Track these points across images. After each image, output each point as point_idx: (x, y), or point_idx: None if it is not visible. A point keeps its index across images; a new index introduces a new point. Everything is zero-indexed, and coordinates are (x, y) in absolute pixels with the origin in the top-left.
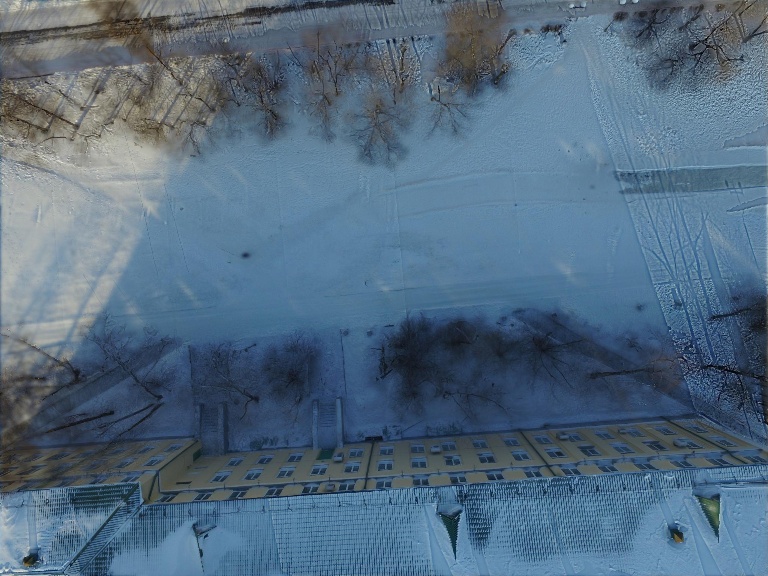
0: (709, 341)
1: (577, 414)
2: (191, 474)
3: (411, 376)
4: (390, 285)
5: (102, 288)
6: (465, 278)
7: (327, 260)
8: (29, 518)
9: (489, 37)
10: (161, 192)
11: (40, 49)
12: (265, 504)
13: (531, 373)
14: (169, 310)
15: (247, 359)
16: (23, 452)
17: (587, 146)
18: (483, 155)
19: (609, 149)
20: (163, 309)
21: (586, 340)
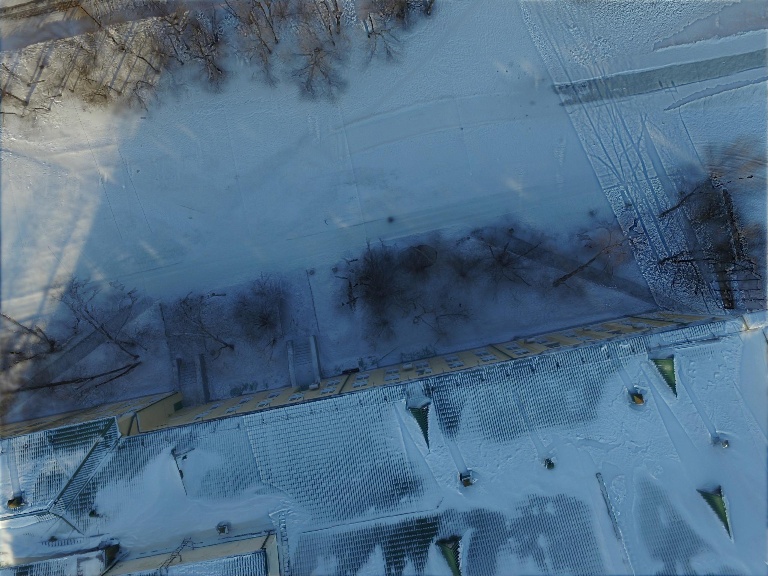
0: (662, 237)
1: (545, 323)
2: (172, 420)
3: (379, 304)
4: (350, 221)
5: (68, 258)
6: (421, 205)
7: (286, 204)
8: (10, 465)
9: None
10: (116, 157)
11: None
12: (240, 422)
13: None
14: (136, 271)
15: (218, 310)
16: (6, 426)
17: (524, 64)
18: (425, 85)
19: (545, 65)
20: (130, 271)
21: (545, 251)
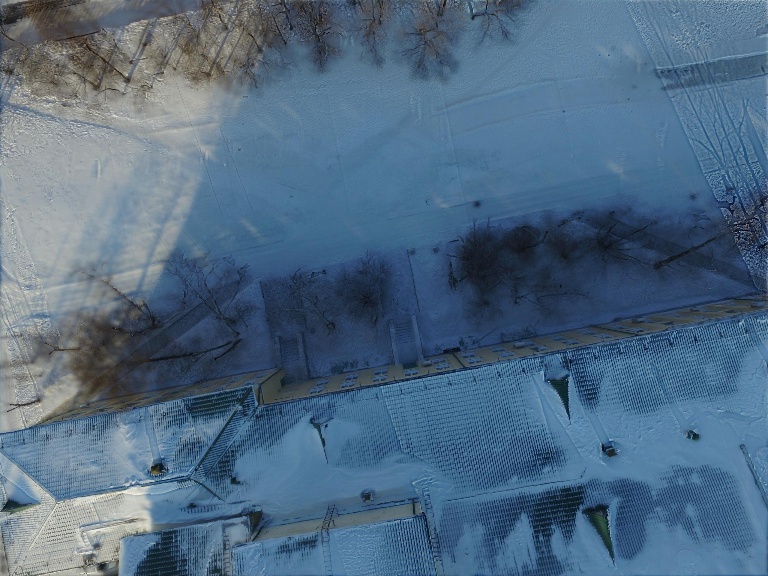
0: (763, 221)
1: (645, 305)
2: (285, 394)
3: (483, 283)
4: (450, 202)
5: (168, 235)
6: (523, 187)
7: (387, 184)
8: (148, 432)
9: None
10: (217, 135)
11: (83, 9)
12: (378, 392)
13: (597, 270)
14: (237, 249)
15: (319, 288)
16: (109, 401)
17: (626, 48)
18: (527, 67)
19: (647, 49)
20: (231, 249)
21: (645, 234)
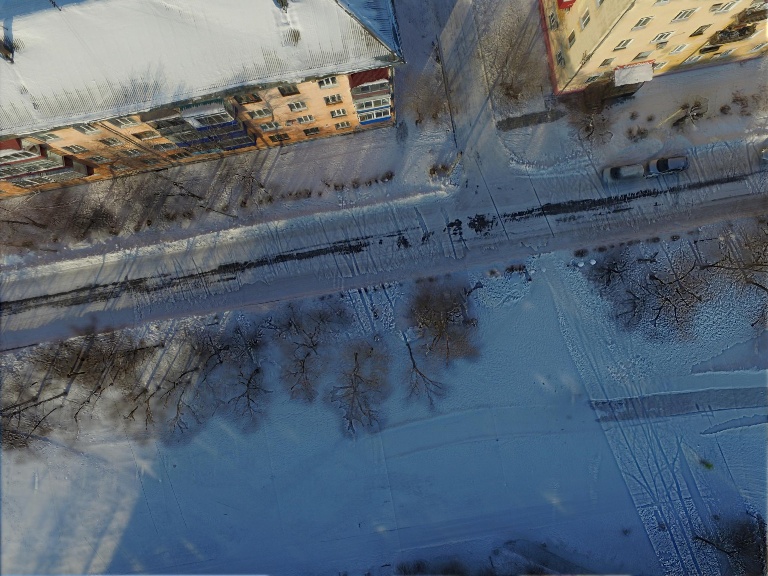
0: (695, 559)
1: None
2: None
3: None
4: (383, 525)
5: (104, 549)
6: (455, 514)
7: (320, 505)
8: None
9: (457, 280)
10: (153, 451)
11: (23, 319)
12: None
13: None
14: (171, 565)
15: None
16: None
17: (561, 377)
18: (461, 393)
19: (582, 379)
20: (165, 565)
21: (577, 566)
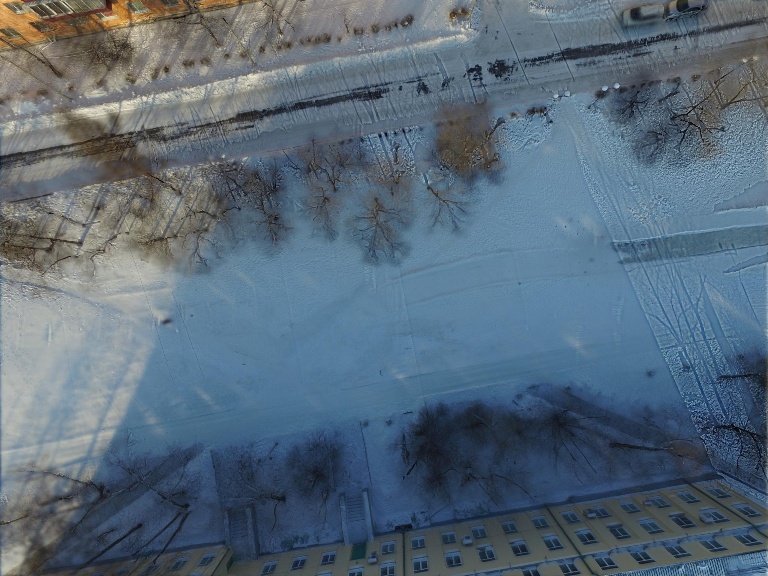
0: (720, 400)
1: (600, 483)
2: None
3: (435, 464)
4: (404, 372)
5: (119, 401)
6: (477, 359)
7: (340, 353)
8: None
9: (478, 123)
10: (170, 301)
11: (37, 170)
12: None
13: (551, 448)
14: (188, 417)
15: None
16: (54, 575)
17: (583, 220)
18: (483, 237)
19: (604, 221)
20: (182, 416)
21: (601, 409)
